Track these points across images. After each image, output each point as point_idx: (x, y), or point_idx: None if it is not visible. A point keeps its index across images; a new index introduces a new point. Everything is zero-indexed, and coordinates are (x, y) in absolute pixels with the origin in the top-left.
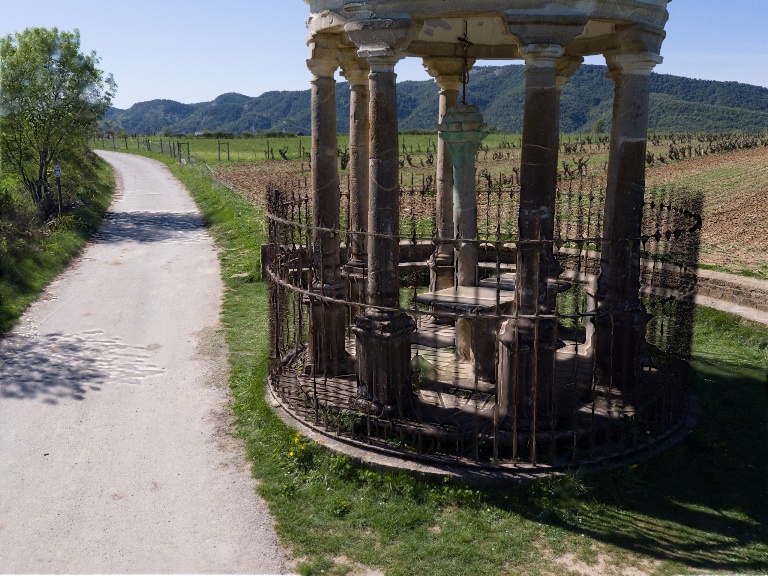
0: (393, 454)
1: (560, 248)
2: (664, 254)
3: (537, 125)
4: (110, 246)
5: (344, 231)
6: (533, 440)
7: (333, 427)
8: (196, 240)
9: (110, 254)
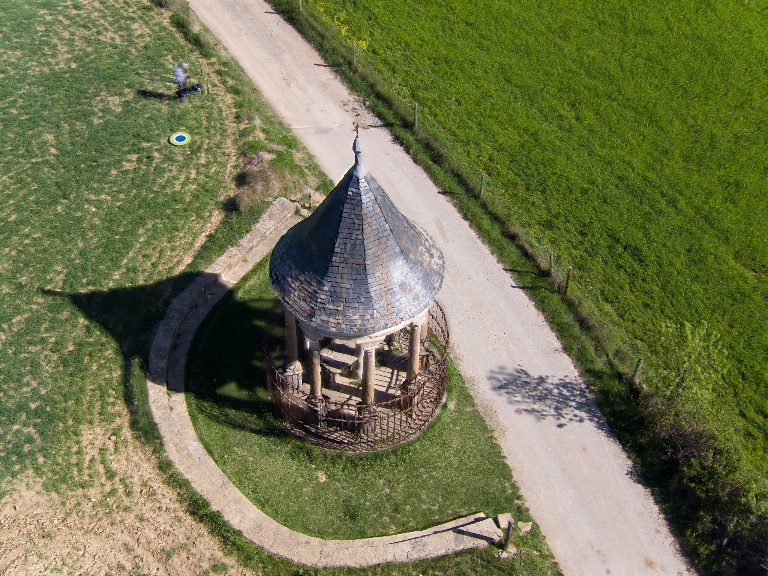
0: None
1: (268, 542)
2: None
3: None
4: None
5: None
6: None
7: None
8: None
9: None
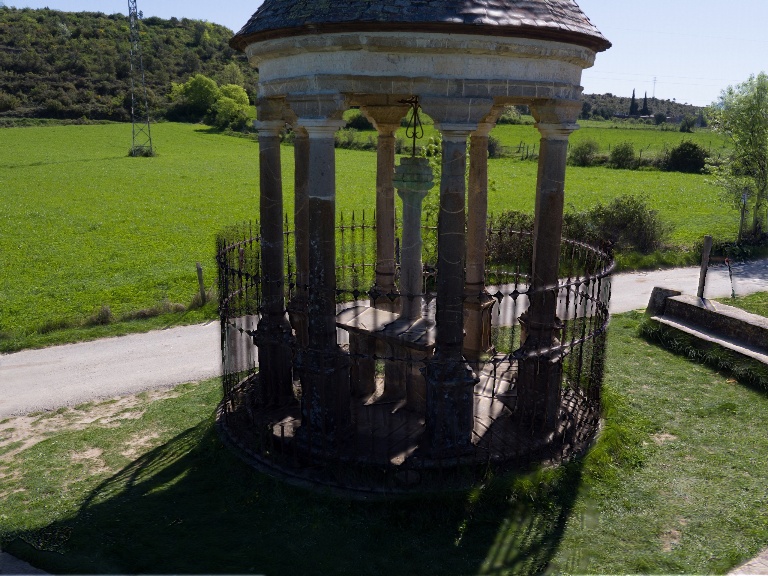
0: None
1: None
2: None
3: None
4: (698, 271)
5: None
6: None
7: None
8: (767, 285)
9: (669, 275)
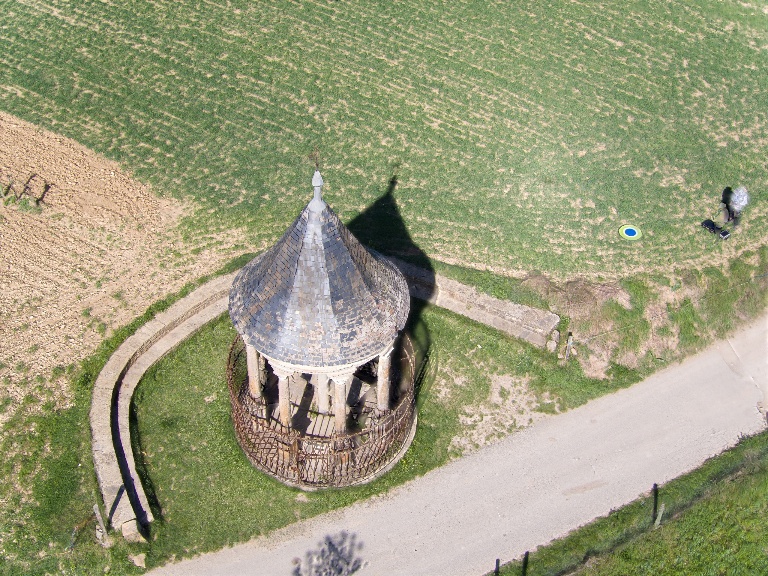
0: None
1: (122, 353)
2: (163, 304)
3: None
4: None
5: None
6: None
7: None
8: None
9: None
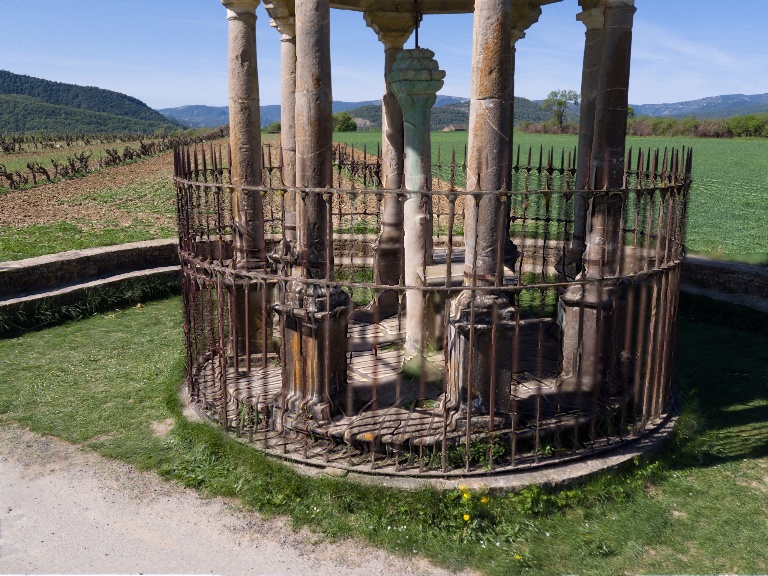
0: (569, 462)
1: (275, 235)
2: None
3: (626, 67)
4: None
5: (522, 191)
6: (661, 393)
7: (469, 464)
8: None
9: None
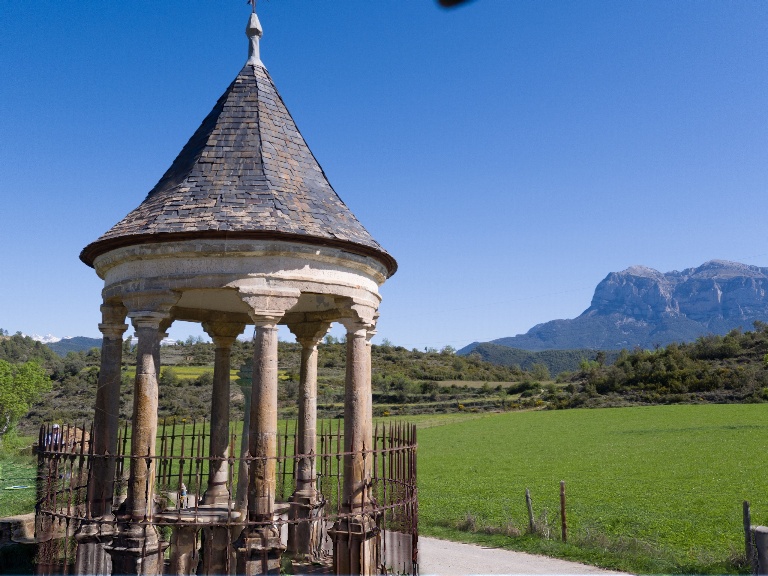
0: None
1: None
2: None
3: None
4: None
5: None
6: None
7: None
8: None
9: None
